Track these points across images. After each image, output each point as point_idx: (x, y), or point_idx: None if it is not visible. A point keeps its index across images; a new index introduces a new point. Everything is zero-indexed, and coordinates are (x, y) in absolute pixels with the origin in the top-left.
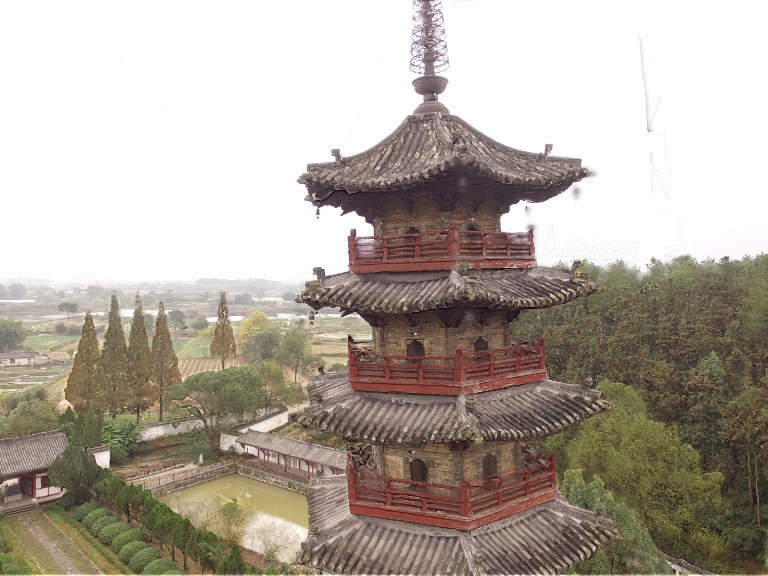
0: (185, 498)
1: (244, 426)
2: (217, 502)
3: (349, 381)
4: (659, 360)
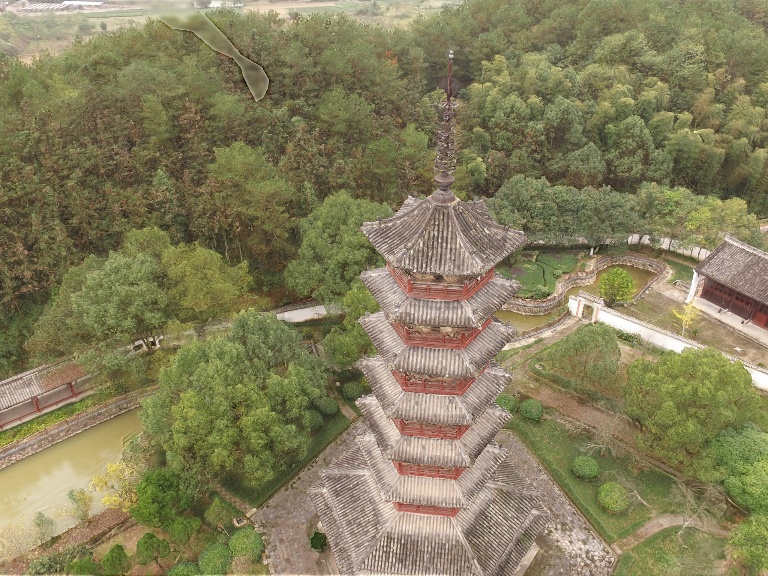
0: None
1: None
2: None
3: (410, 350)
4: (114, 188)
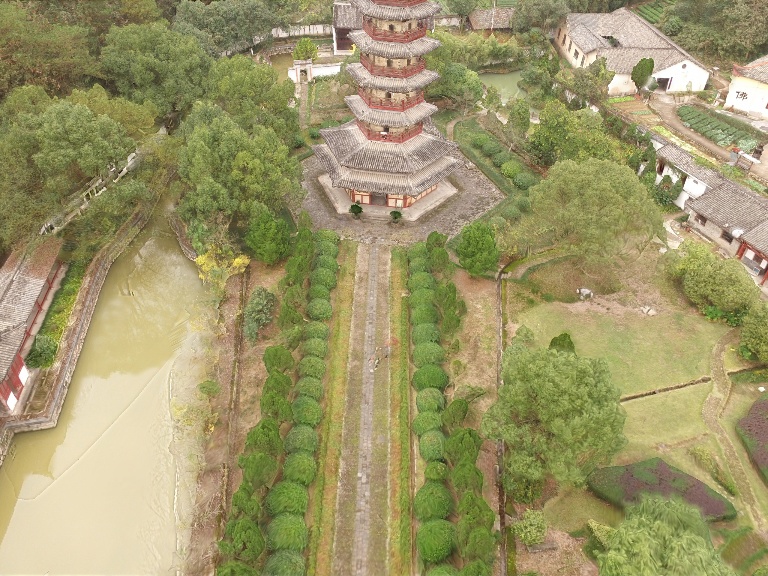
0: None
1: None
2: (182, 444)
3: None
4: None
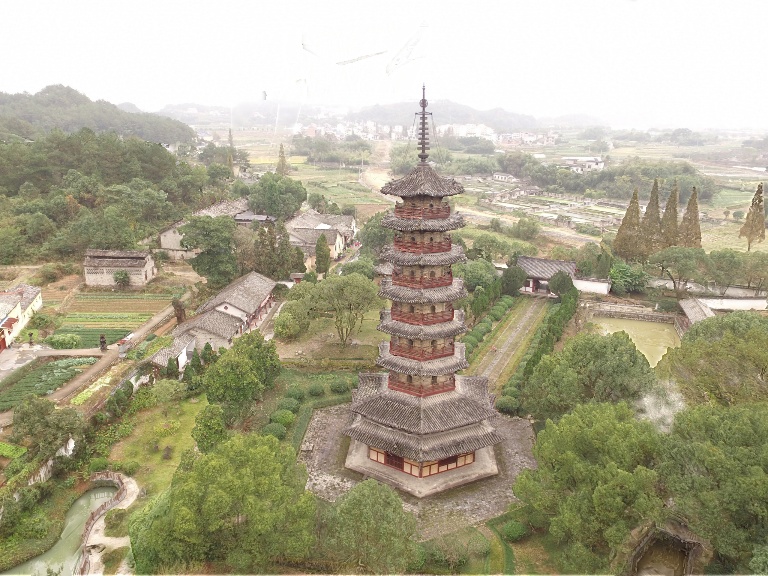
0: (628, 325)
1: (717, 297)
2: None
3: None
4: None
